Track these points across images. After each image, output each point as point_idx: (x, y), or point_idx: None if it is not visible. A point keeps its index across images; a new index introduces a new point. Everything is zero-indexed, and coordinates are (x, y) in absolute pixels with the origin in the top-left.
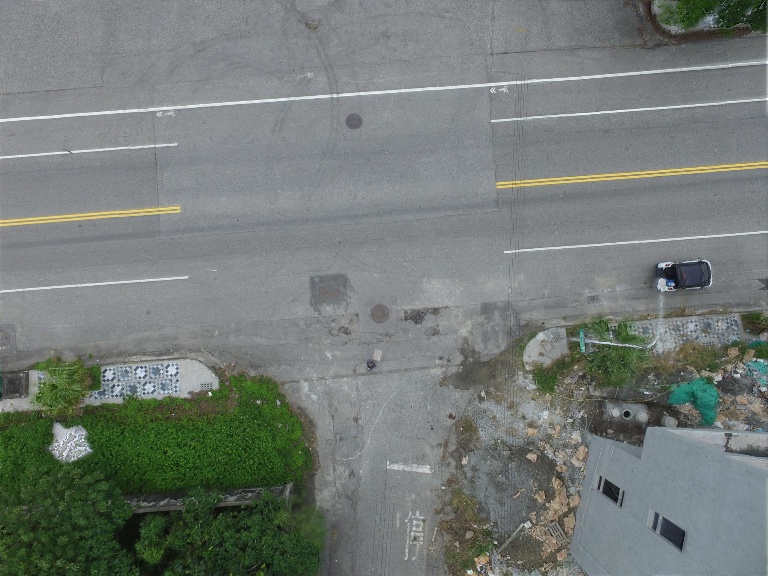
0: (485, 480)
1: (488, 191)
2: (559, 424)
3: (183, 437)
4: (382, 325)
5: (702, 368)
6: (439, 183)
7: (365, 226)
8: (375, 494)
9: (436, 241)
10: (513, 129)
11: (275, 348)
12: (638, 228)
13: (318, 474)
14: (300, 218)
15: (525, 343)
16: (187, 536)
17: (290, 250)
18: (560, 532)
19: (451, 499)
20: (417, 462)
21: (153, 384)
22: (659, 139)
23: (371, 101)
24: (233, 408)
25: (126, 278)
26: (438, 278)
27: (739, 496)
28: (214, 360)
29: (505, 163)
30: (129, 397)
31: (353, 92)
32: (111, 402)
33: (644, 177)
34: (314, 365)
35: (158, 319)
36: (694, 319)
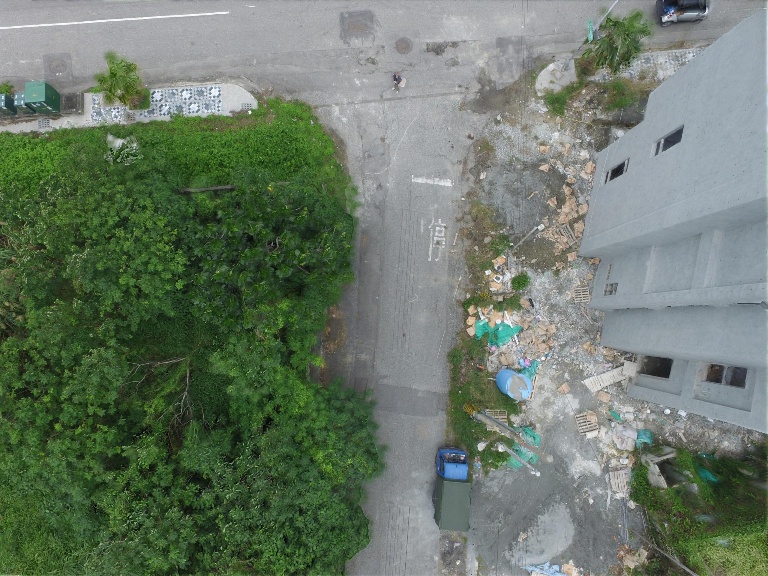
0: (501, 190)
1: None
2: (569, 143)
3: (227, 139)
4: (406, 56)
5: None
6: None
7: None
8: (401, 203)
9: None
10: None
11: (308, 75)
12: None
13: (348, 187)
14: None
15: (537, 74)
16: (235, 196)
17: None
18: (570, 233)
19: (470, 209)
20: (439, 176)
21: (198, 104)
22: None
23: None
24: (271, 121)
25: (172, 13)
26: (457, 15)
27: (730, 50)
28: (253, 86)
29: None
30: (176, 115)
31: None
32: (159, 120)
33: None
34: (344, 91)
35: (201, 49)
36: (692, 50)
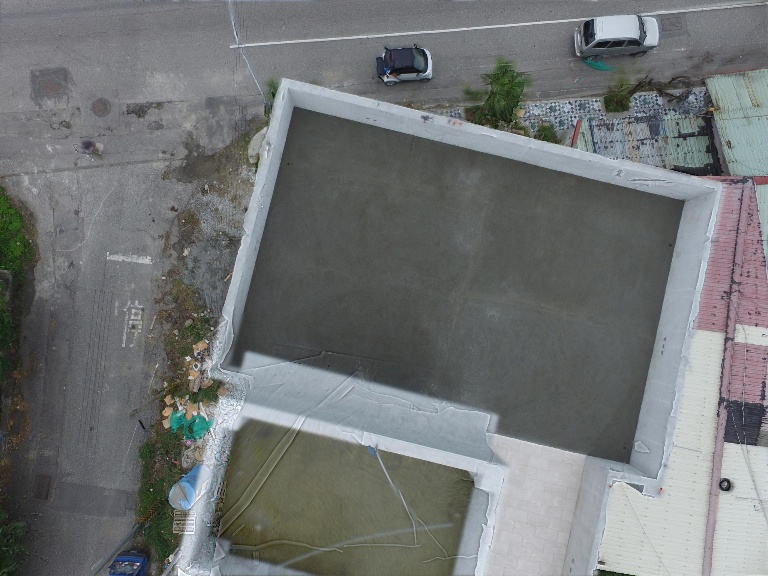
0: (203, 269)
1: None
2: None
3: None
4: (104, 118)
5: None
6: None
7: (87, 19)
8: (94, 284)
9: (160, 35)
10: None
11: None
12: (365, 22)
13: (38, 265)
14: (20, 11)
15: (251, 138)
16: None
17: (9, 43)
18: None
19: (171, 289)
20: (138, 253)
21: None
22: None
23: None
24: None
25: None
26: (162, 72)
27: None
28: None
29: None
30: None
31: None
32: None
33: None
34: (34, 158)
35: None
36: None
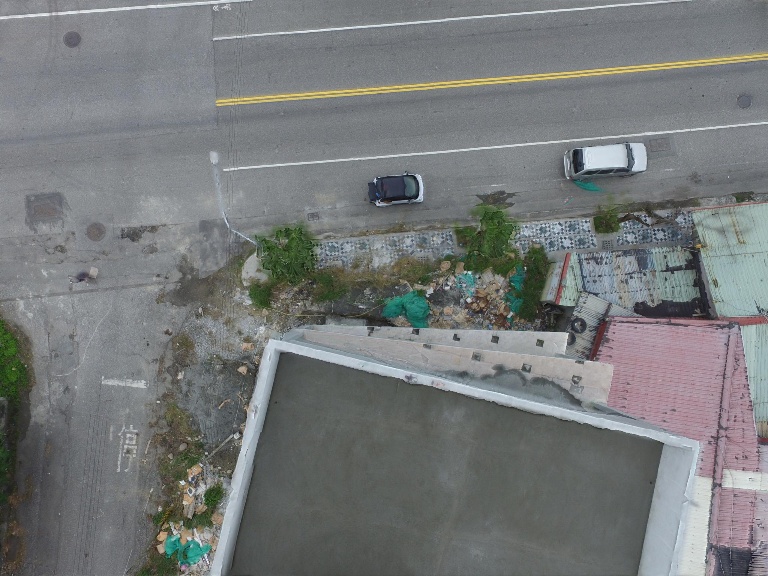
0: (198, 393)
1: (208, 109)
2: None
3: None
4: (98, 243)
5: (414, 281)
6: (158, 101)
7: (82, 145)
8: (89, 409)
9: (154, 159)
10: (234, 47)
11: None
12: (357, 145)
13: (33, 390)
14: (15, 137)
15: (244, 260)
16: None
17: (5, 169)
18: None
19: (166, 413)
20: (132, 377)
21: None
22: (381, 56)
23: (90, 19)
24: None
25: None
26: (156, 196)
27: None
28: None
29: (226, 81)
30: None
31: (73, 10)
32: None
33: (364, 94)
34: (30, 283)
35: None
36: (410, 234)
